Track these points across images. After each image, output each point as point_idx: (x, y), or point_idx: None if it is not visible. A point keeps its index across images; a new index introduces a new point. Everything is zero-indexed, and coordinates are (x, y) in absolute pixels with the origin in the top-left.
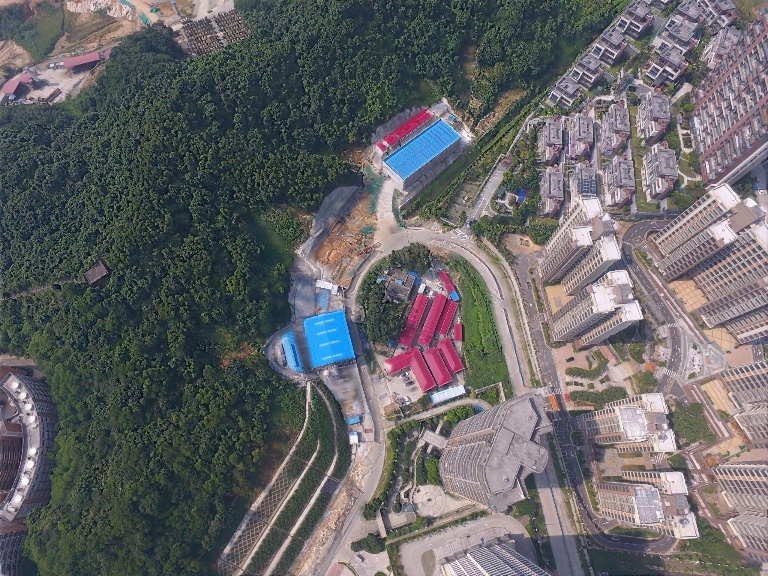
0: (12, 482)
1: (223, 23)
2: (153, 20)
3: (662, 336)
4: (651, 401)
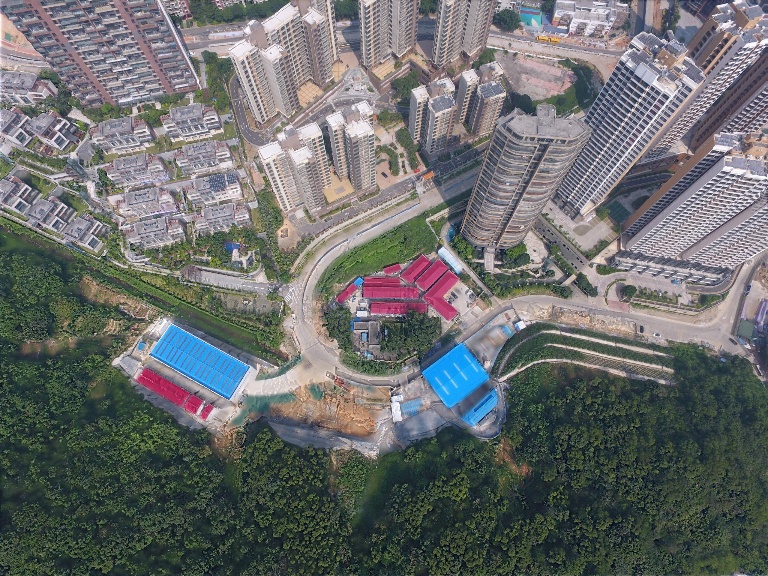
0: None
1: None
2: None
3: None
4: (420, 96)
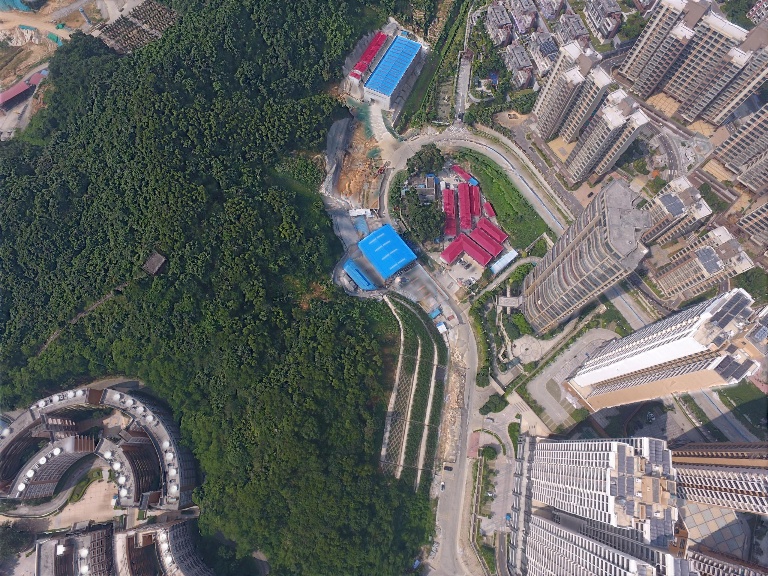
0: (153, 485)
1: (142, 16)
2: (64, 36)
3: (655, 146)
4: (678, 184)
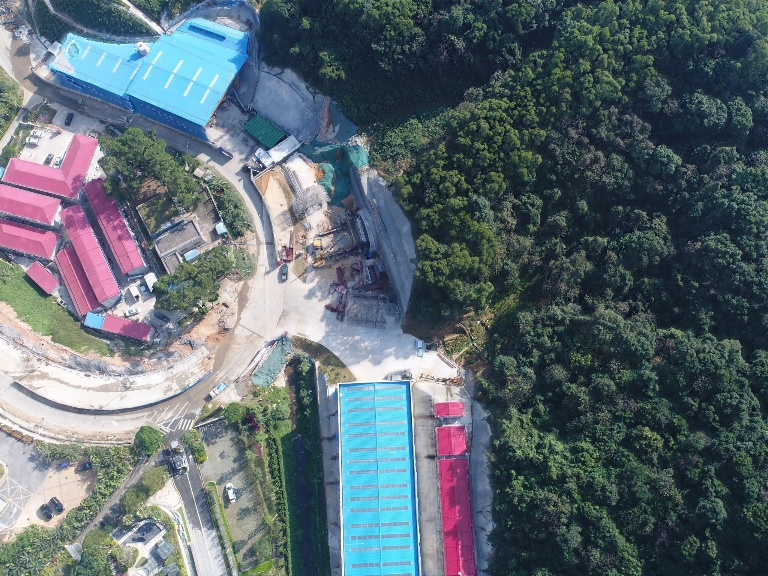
0: None
1: None
2: None
3: None
4: None
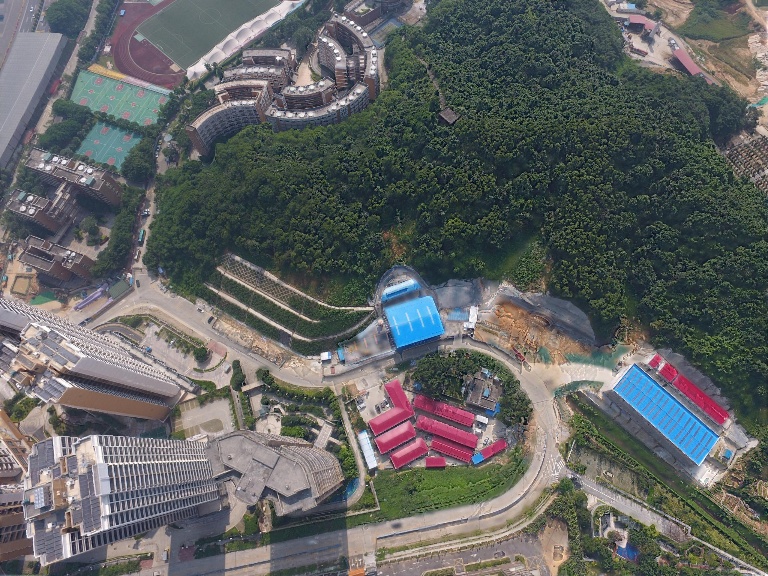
0: None
1: None
2: (765, 109)
3: None
4: None
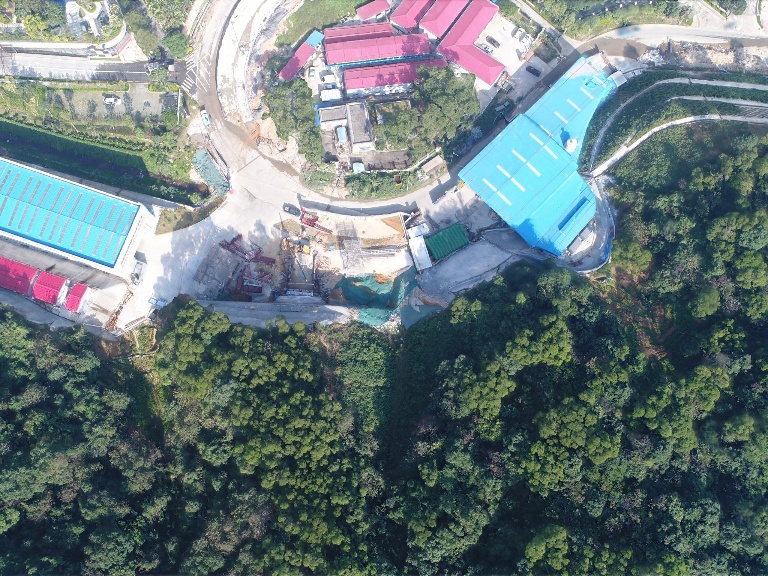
0: None
1: None
2: None
3: None
4: None
